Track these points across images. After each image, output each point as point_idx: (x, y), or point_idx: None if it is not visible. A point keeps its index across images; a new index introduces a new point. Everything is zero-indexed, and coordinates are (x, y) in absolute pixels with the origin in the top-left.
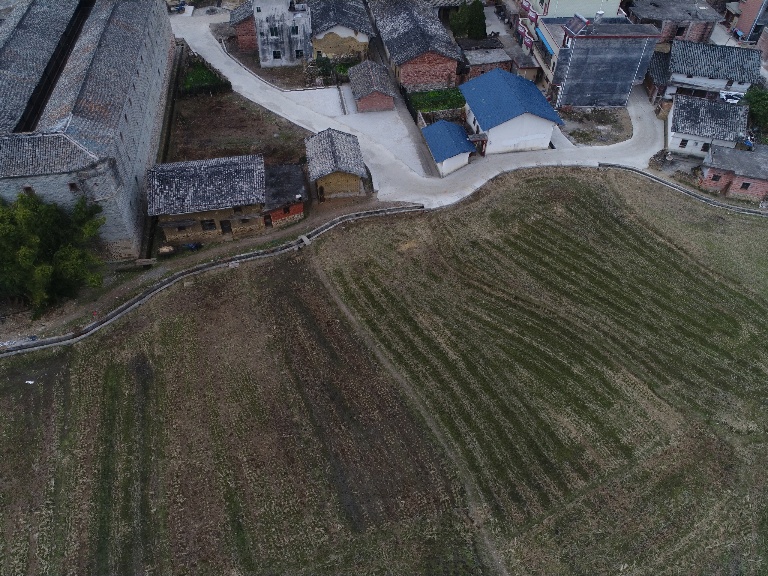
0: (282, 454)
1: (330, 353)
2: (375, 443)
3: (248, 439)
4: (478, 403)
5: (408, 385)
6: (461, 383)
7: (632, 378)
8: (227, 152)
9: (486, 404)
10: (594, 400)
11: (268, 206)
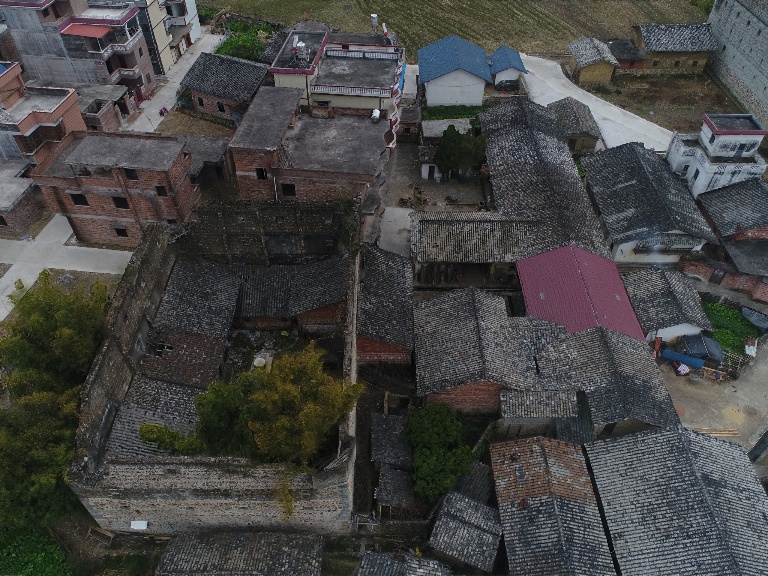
0: (585, 2)
1: (573, 18)
2: (550, 1)
3: (600, 5)
4: (509, 2)
5: (538, 7)
6: (515, 6)
7: (443, 1)
8: (685, 101)
9: (506, 2)
10: (462, 0)
11: (628, 39)
